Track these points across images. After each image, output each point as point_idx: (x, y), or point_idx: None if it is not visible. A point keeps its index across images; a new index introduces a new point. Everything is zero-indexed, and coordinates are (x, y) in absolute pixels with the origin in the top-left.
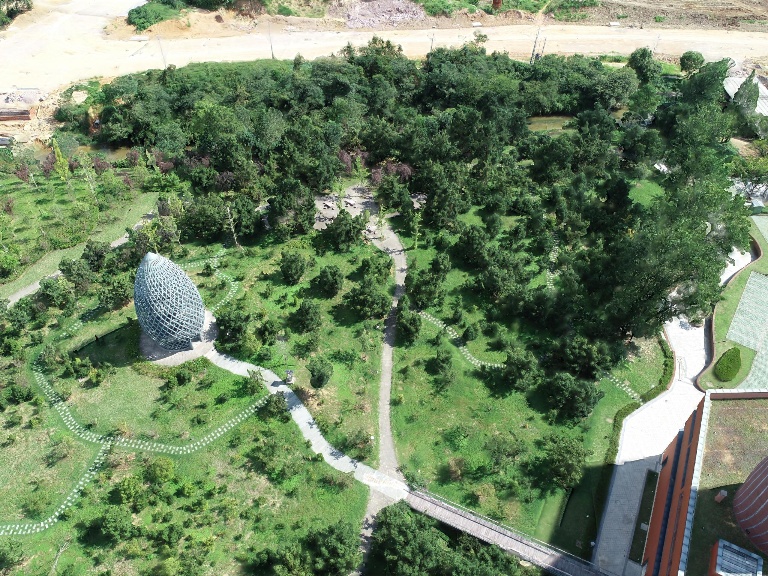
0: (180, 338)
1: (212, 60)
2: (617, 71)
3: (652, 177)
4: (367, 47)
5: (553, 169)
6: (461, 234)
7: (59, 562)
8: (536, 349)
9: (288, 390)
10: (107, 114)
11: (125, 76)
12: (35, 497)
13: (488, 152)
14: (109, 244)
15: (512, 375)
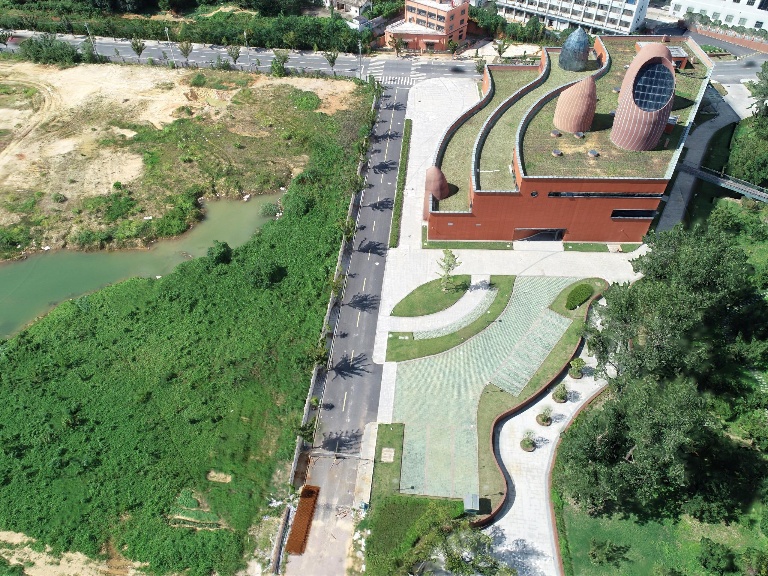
0: None
1: None
2: None
3: None
4: None
5: None
6: None
7: None
8: None
9: None
10: None
11: None
12: None
13: None
14: None
15: None
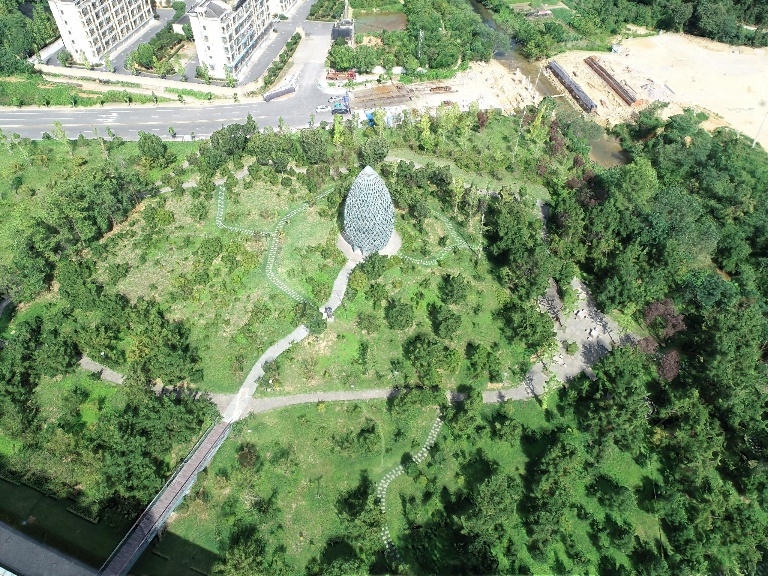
0: None
1: None
2: None
3: None
4: None
5: None
6: None
7: (197, 238)
8: (417, 561)
9: None
10: None
11: (727, 127)
12: (234, 213)
13: (765, 470)
14: (450, 177)
15: None
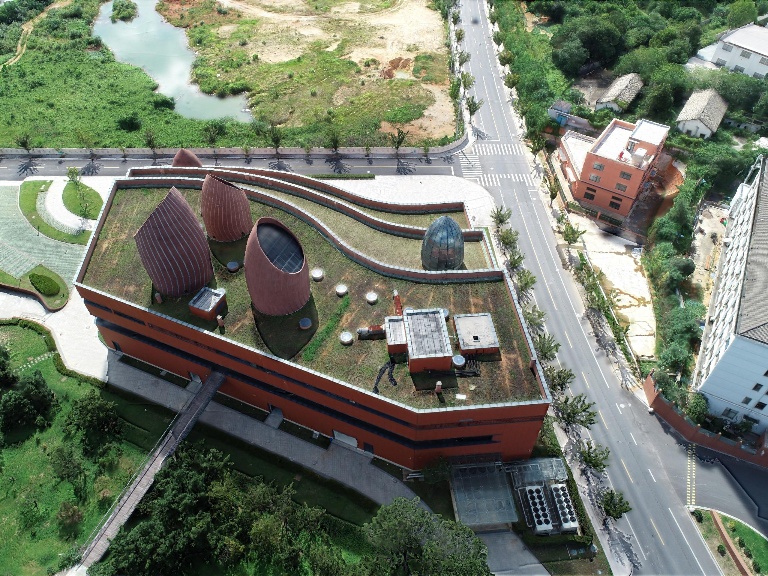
0: None
1: None
2: None
3: None
4: None
5: None
6: None
7: None
8: None
9: None
10: None
11: None
12: None
13: None
14: None
15: None
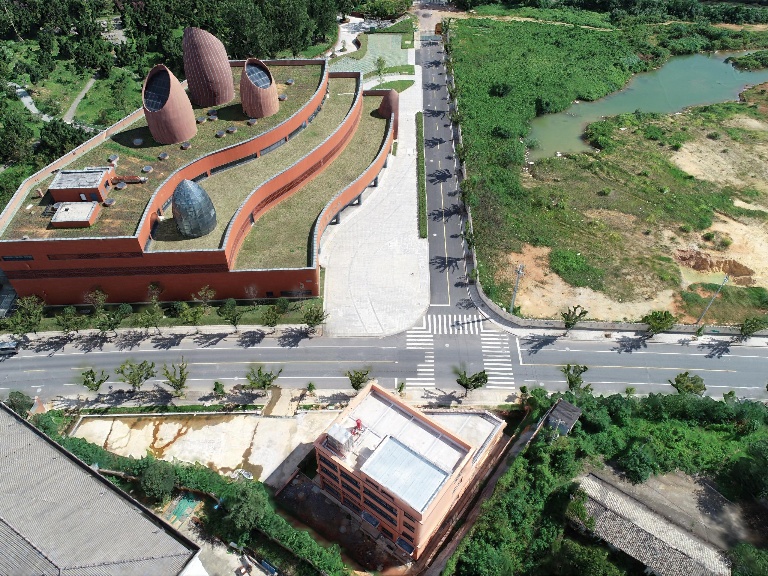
0: None
1: None
2: None
3: None
4: None
5: None
6: None
7: None
8: None
9: (23, 90)
10: None
11: None
12: None
13: None
14: None
15: None
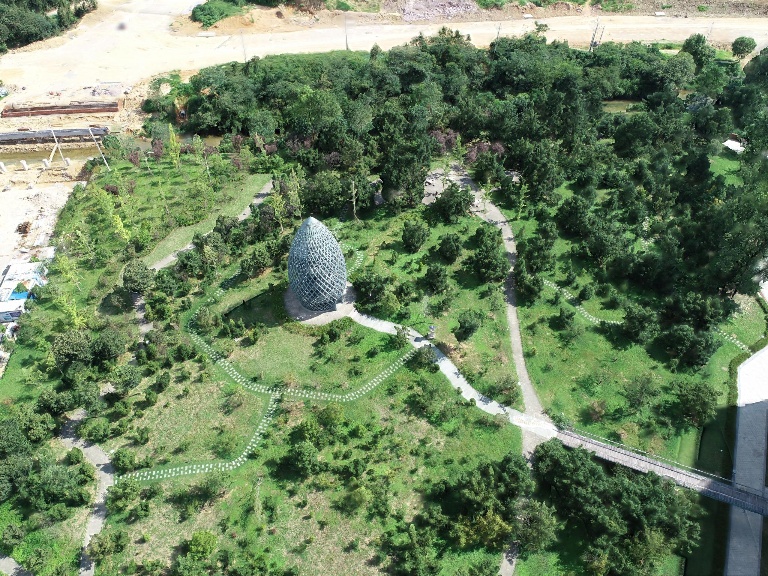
0: (329, 298)
1: (281, 53)
2: (676, 56)
3: (722, 154)
4: (438, 37)
5: (638, 145)
6: (563, 205)
7: None
8: None
9: None
10: (193, 104)
11: None
12: (225, 439)
13: (575, 130)
14: (238, 219)
15: (633, 328)
